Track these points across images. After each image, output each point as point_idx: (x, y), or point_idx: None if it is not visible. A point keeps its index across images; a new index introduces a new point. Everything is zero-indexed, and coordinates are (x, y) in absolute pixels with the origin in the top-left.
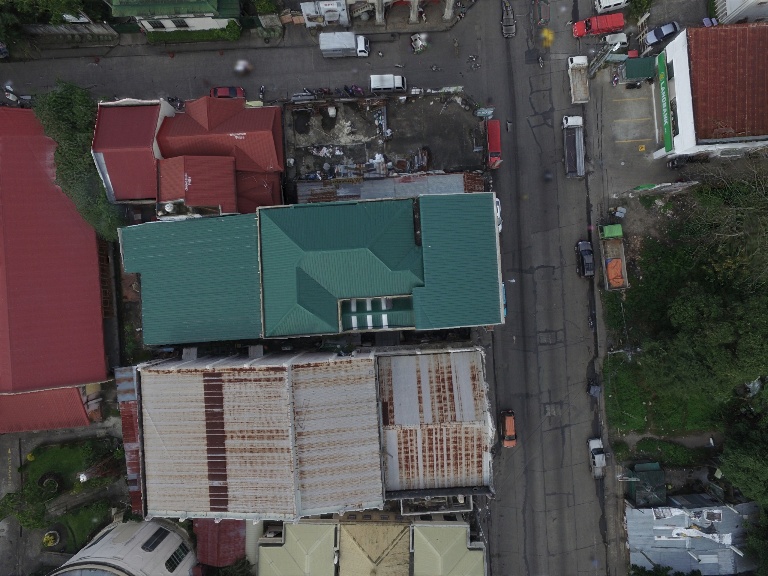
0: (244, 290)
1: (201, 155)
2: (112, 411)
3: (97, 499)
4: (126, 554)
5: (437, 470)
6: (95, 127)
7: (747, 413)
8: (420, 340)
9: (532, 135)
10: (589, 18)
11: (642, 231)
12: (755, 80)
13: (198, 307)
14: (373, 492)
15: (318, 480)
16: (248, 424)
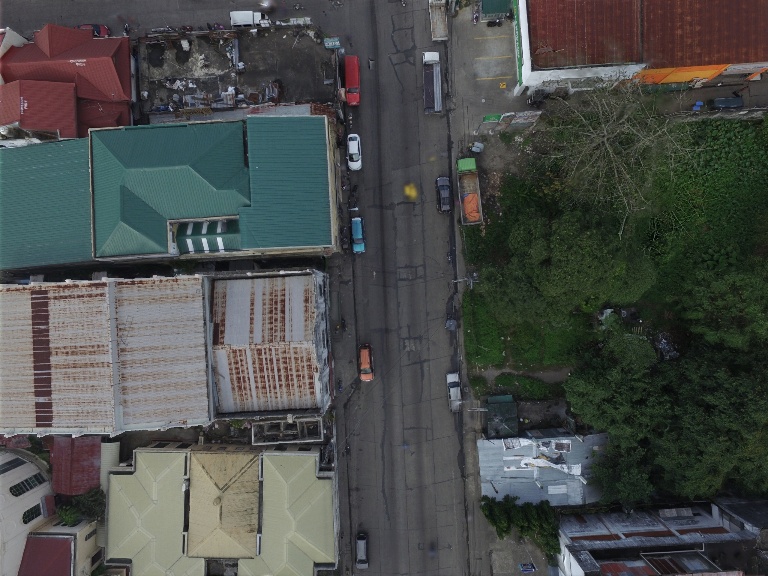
0: (80, 213)
1: (39, 80)
2: None
3: None
4: None
5: (270, 392)
6: None
7: None
8: None
9: (394, 73)
10: None
11: (502, 167)
12: (594, 8)
13: (38, 231)
14: (199, 410)
15: (141, 396)
16: (71, 340)
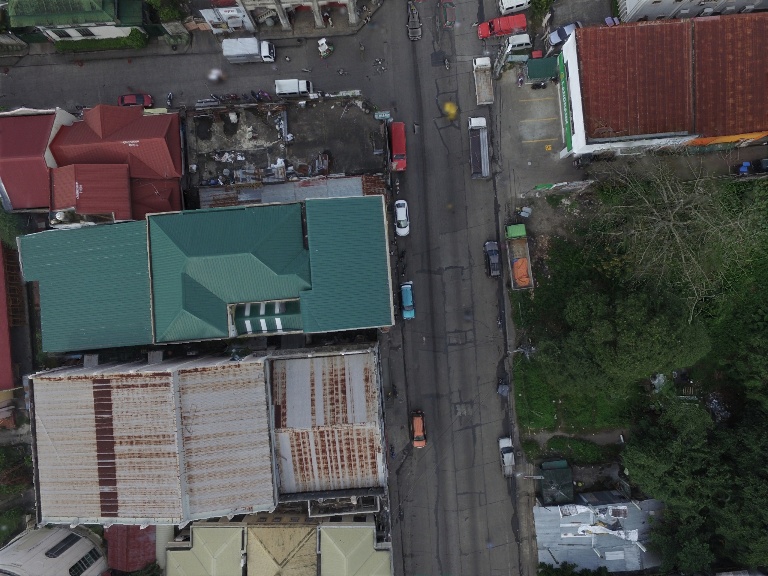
0: (138, 296)
1: (93, 163)
2: (26, 418)
3: (12, 506)
4: (26, 561)
5: (332, 472)
6: None
7: (656, 409)
8: (326, 343)
9: (439, 137)
10: (492, 20)
11: (549, 230)
12: (645, 79)
13: (94, 314)
14: (264, 495)
15: (207, 484)
16: (136, 430)
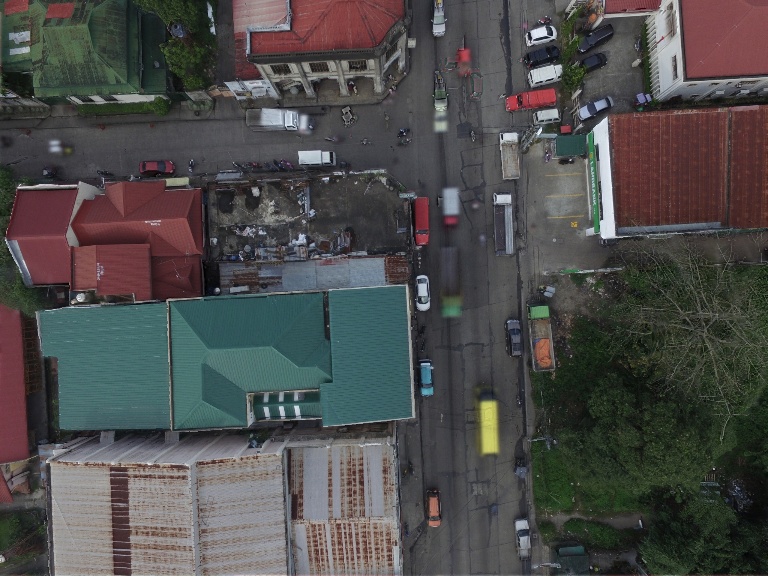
0: (156, 379)
1: (114, 244)
2: (40, 483)
3: (25, 570)
4: None
5: (347, 563)
6: (11, 213)
7: (676, 496)
8: None
9: (463, 210)
10: (520, 94)
11: (573, 309)
12: (679, 168)
13: (112, 394)
14: None
15: None
16: (152, 520)
